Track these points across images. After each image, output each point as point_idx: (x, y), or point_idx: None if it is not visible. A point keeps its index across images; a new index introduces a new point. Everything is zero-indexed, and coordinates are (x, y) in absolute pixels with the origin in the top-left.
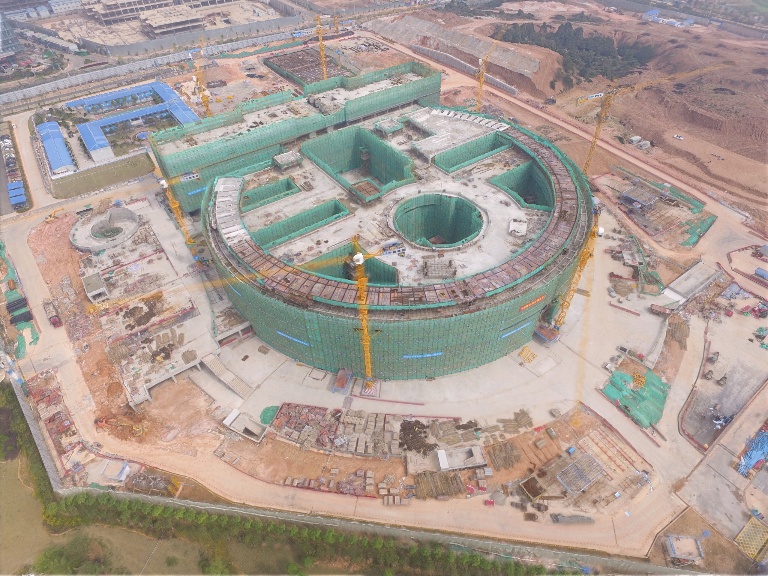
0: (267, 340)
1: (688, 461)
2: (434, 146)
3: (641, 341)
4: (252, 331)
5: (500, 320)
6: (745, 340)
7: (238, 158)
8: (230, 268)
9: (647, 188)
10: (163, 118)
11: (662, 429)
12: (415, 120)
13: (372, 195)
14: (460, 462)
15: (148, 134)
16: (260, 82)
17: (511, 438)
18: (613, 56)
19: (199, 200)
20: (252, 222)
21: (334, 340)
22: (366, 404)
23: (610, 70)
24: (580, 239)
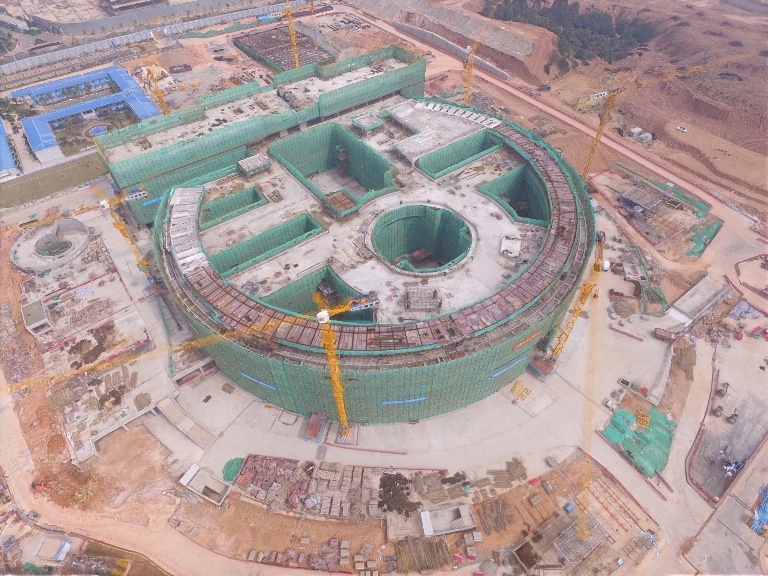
0: (232, 377)
1: (697, 516)
2: (418, 147)
3: (644, 372)
4: (215, 366)
5: (491, 361)
6: (756, 368)
7: (198, 163)
8: (185, 300)
9: (649, 188)
10: (120, 110)
11: (668, 477)
12: (397, 115)
13: (348, 209)
14: (446, 524)
15: (94, 137)
16: (229, 66)
17: (503, 493)
18: (611, 34)
19: (156, 210)
20: (212, 241)
21: (304, 387)
22: (342, 454)
23: (608, 51)
24: (579, 260)
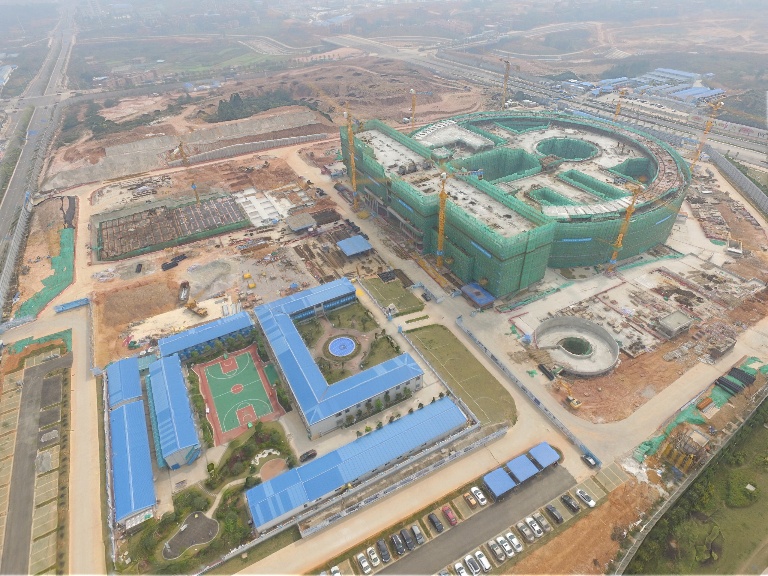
0: None
1: None
2: (478, 141)
3: None
4: None
5: None
6: None
7: None
8: None
9: None
10: None
11: None
12: None
13: (559, 157)
14: None
15: None
16: (201, 257)
17: None
18: None
19: None
20: None
21: None
22: None
23: None
24: None
